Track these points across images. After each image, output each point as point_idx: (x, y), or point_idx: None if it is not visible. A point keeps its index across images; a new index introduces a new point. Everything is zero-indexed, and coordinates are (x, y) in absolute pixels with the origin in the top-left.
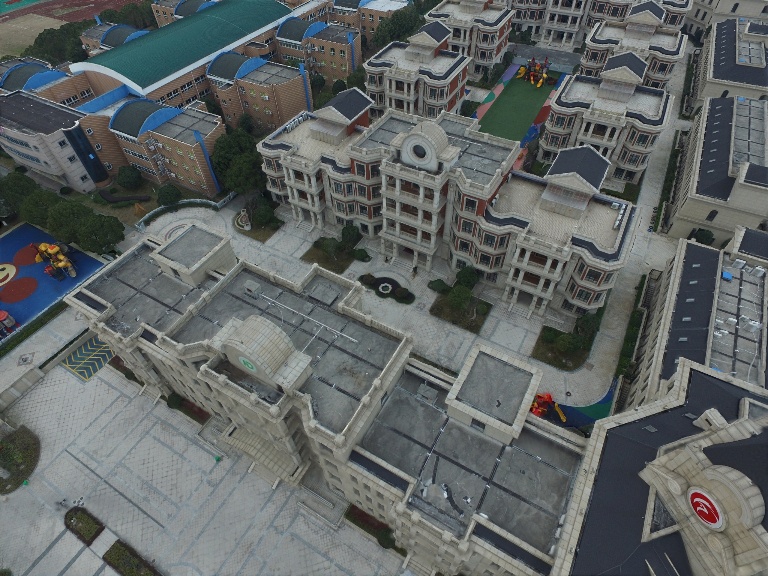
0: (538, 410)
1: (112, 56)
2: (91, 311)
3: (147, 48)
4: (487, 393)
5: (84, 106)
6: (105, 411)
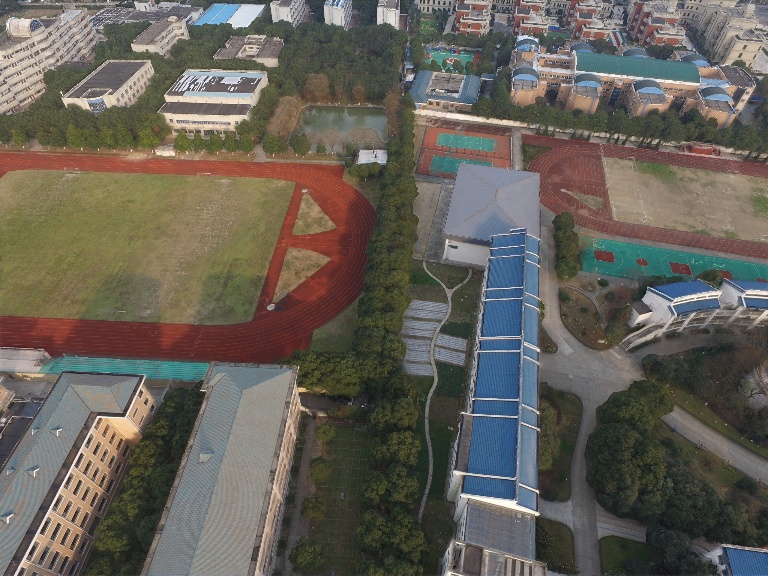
0: (688, 27)
1: (686, 67)
2: (762, 39)
3: (668, 62)
4: (717, 6)
5: (714, 69)
6: (760, 66)
